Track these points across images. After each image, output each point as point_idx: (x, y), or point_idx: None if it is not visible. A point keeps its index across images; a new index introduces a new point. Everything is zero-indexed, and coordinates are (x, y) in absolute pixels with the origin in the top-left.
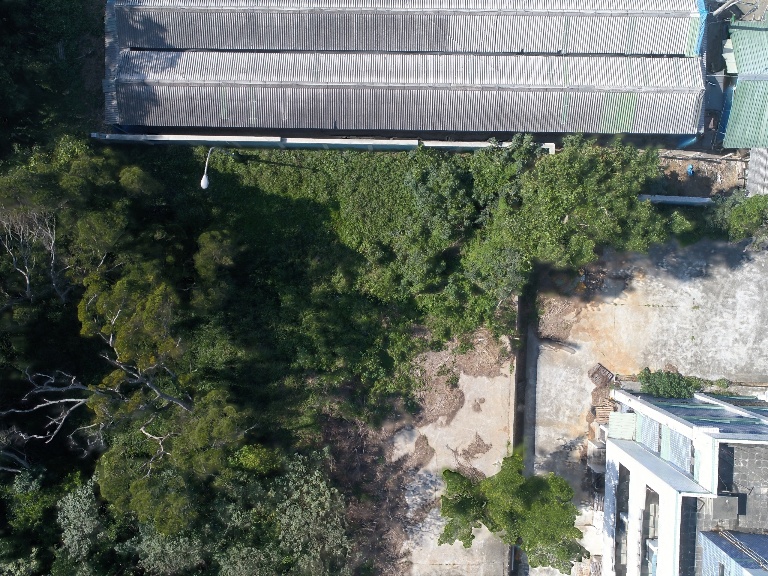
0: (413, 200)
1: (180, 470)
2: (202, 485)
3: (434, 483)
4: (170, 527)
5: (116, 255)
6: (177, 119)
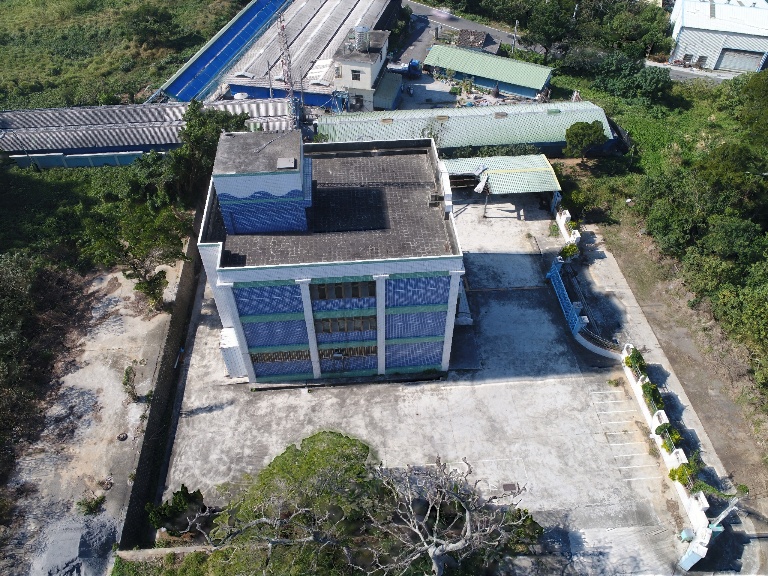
0: None
1: None
2: None
3: (116, 301)
4: None
5: None
6: (5, 148)
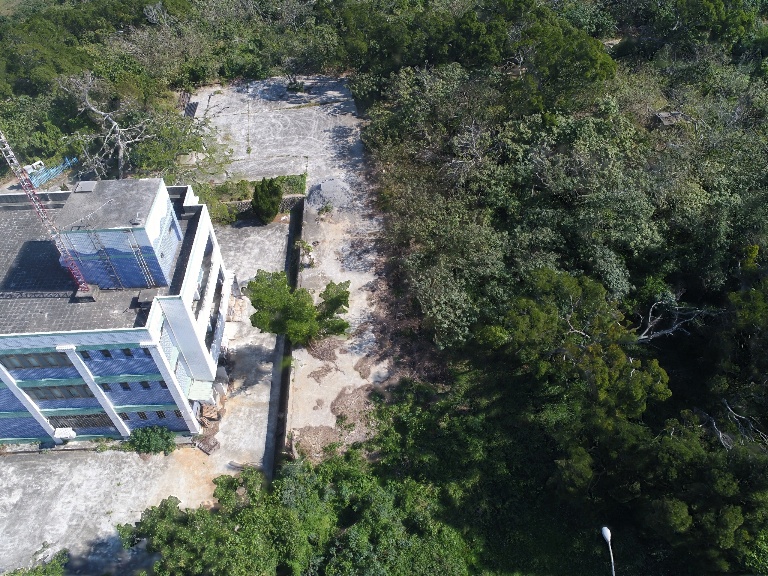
0: None
1: None
2: None
3: (353, 348)
4: None
5: None
6: None
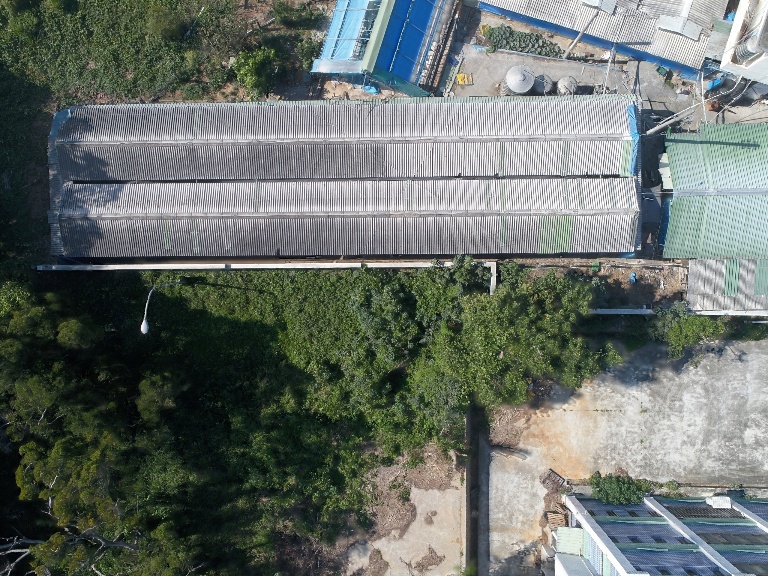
0: (359, 319)
1: None
2: None
3: None
4: None
5: (57, 407)
6: (121, 250)
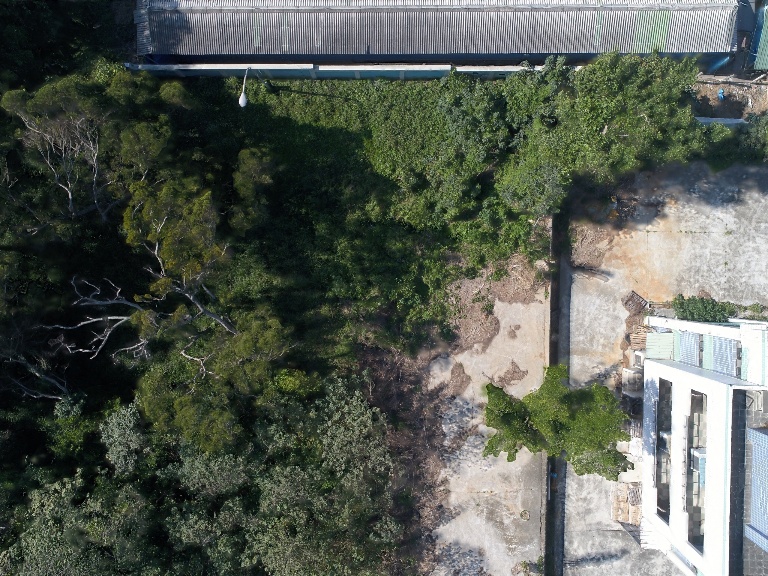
0: (446, 127)
1: (221, 392)
2: (242, 409)
3: (471, 411)
4: (215, 443)
5: (157, 171)
6: (210, 47)
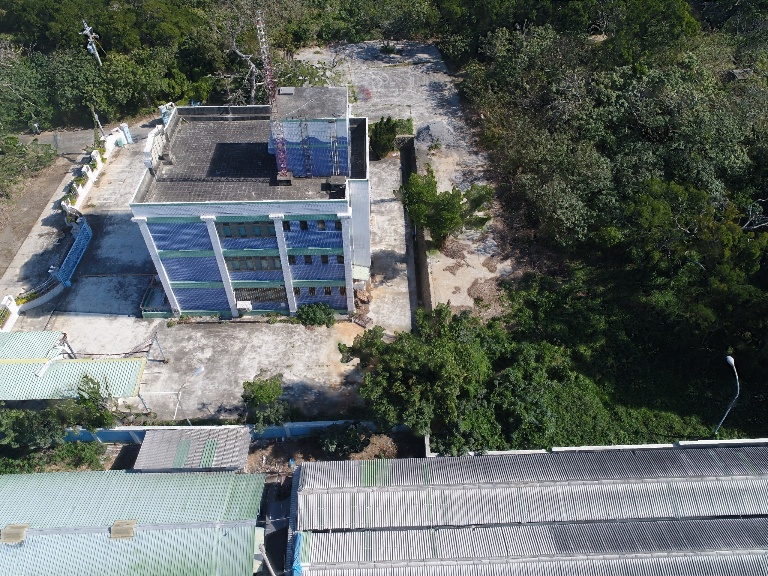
0: None
1: None
2: None
3: (479, 250)
4: None
5: None
6: None
